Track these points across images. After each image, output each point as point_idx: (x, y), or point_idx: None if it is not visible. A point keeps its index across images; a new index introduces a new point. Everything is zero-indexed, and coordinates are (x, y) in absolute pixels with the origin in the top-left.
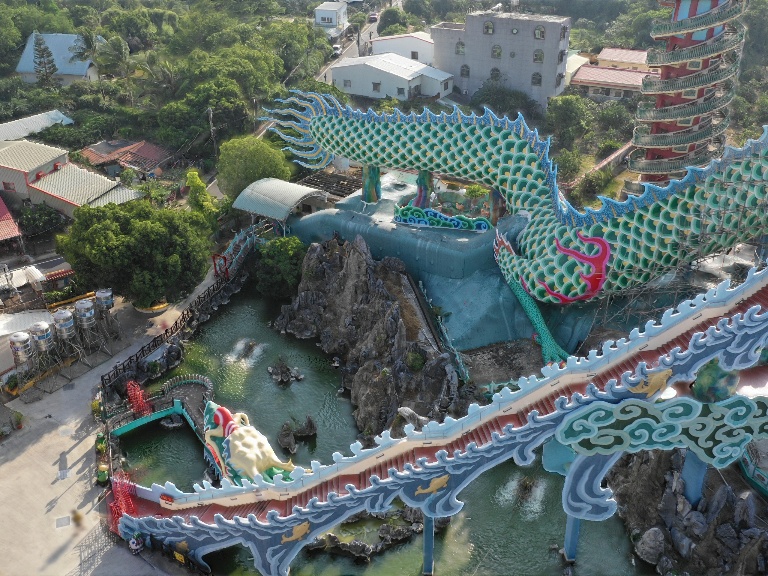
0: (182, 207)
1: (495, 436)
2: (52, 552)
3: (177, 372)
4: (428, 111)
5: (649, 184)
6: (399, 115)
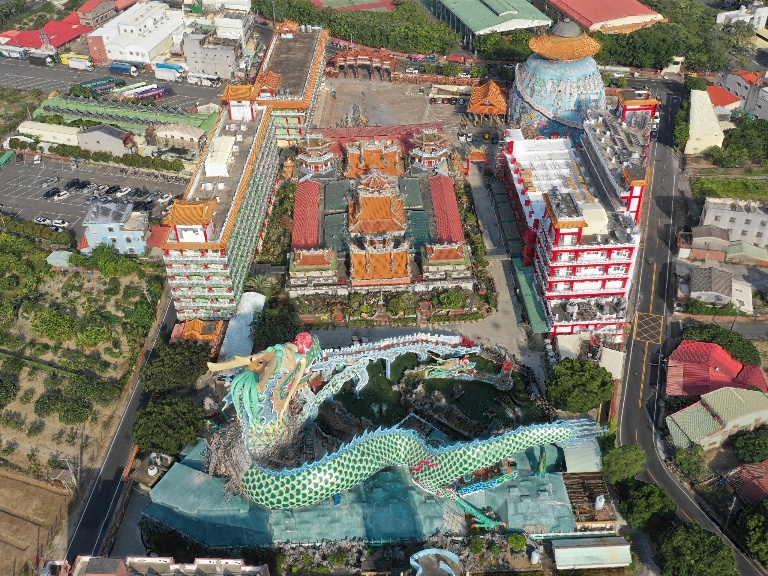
0: (679, 481)
1: (371, 343)
2: (471, 332)
3: (526, 395)
4: (506, 432)
5: (380, 427)
6: (518, 429)
